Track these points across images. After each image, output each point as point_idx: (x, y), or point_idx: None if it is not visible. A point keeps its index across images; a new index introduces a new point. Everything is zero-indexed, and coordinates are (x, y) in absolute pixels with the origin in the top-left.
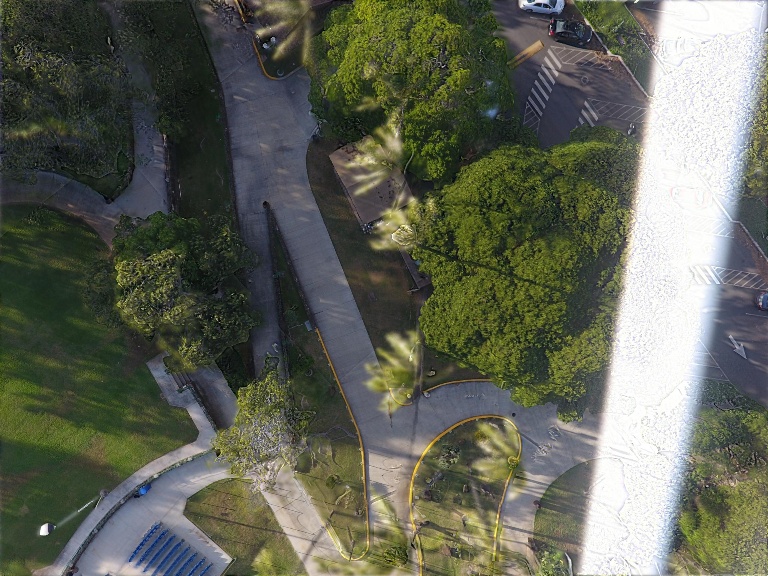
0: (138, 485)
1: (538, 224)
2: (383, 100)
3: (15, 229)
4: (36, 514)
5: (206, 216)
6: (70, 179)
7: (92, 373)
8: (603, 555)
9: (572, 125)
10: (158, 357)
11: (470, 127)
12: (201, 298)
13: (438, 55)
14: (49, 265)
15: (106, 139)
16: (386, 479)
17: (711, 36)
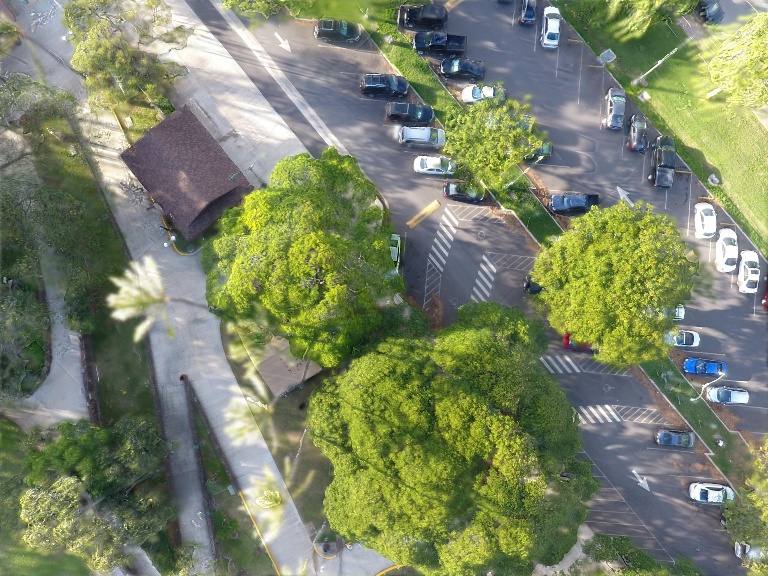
0: None
1: (415, 433)
2: (272, 308)
3: None
4: None
5: (125, 395)
6: None
7: (22, 560)
8: None
9: (472, 278)
10: None
11: (357, 324)
12: (112, 504)
13: (315, 274)
14: None
15: (7, 373)
16: None
17: (598, 186)
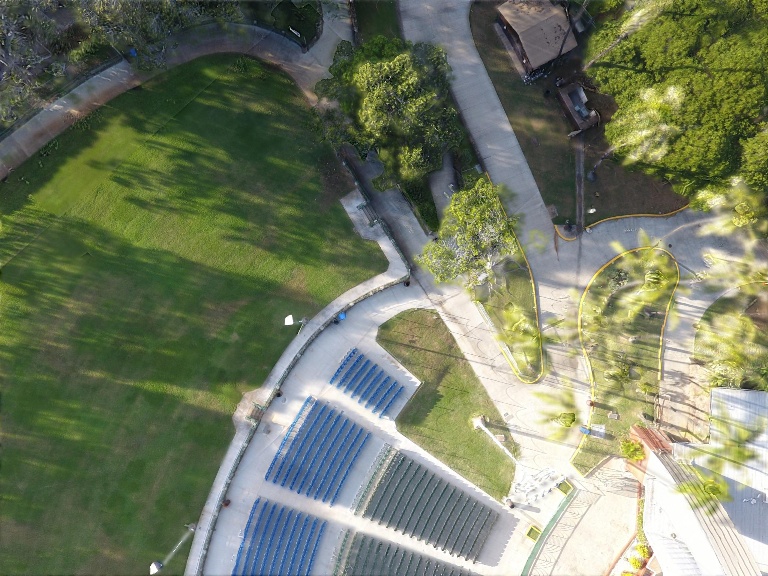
0: (335, 313)
1: (735, 19)
2: None
3: (222, 77)
4: (245, 340)
5: None
6: (270, 31)
7: (292, 209)
8: None
9: None
10: (350, 194)
11: None
12: None
13: None
14: (253, 110)
15: None
16: (556, 308)
17: None
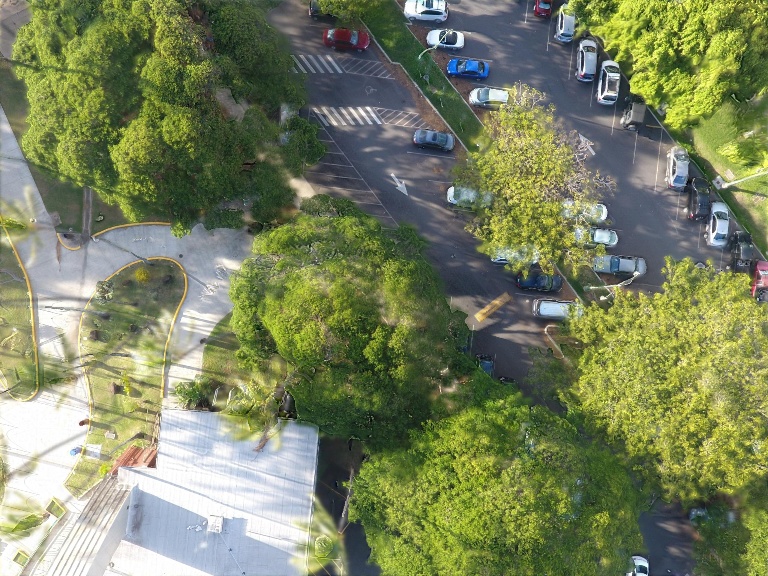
0: None
1: (78, 14)
2: None
3: None
4: None
5: None
6: None
7: None
8: (270, 389)
9: None
10: None
11: None
12: None
13: None
14: None
15: None
16: (55, 322)
17: None
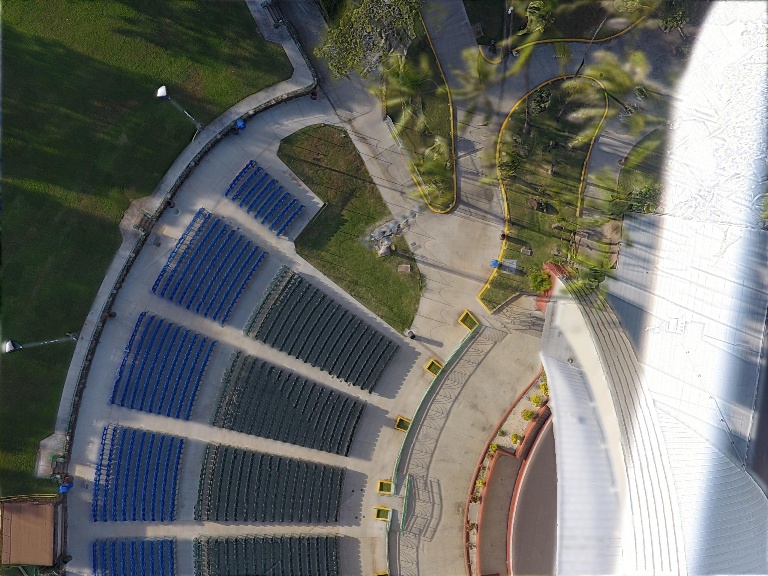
0: (234, 120)
1: None
2: None
3: None
4: (134, 143)
5: None
6: None
7: (189, 1)
8: None
9: None
10: None
11: None
12: None
13: None
14: None
15: None
16: (474, 136)
17: None
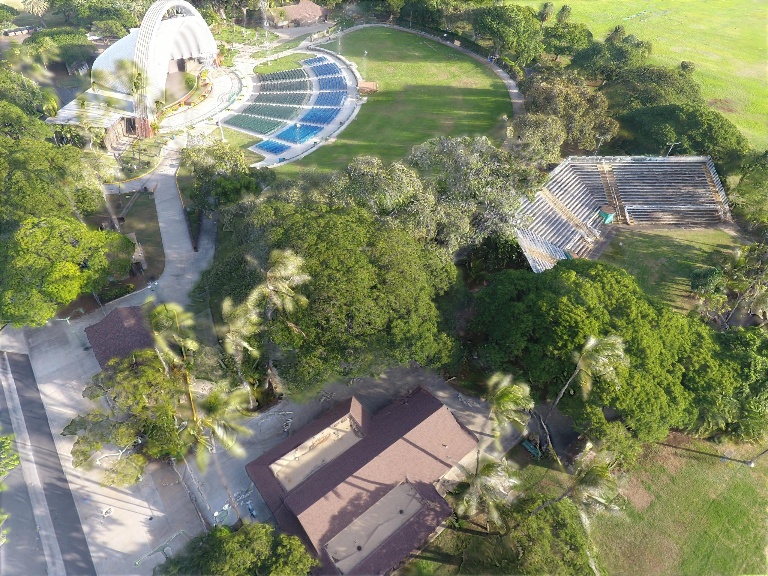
0: None
1: None
2: None
3: None
4: None
5: None
6: None
7: None
8: None
9: None
10: None
11: None
12: None
13: None
14: None
15: None
16: (168, 169)
17: None
